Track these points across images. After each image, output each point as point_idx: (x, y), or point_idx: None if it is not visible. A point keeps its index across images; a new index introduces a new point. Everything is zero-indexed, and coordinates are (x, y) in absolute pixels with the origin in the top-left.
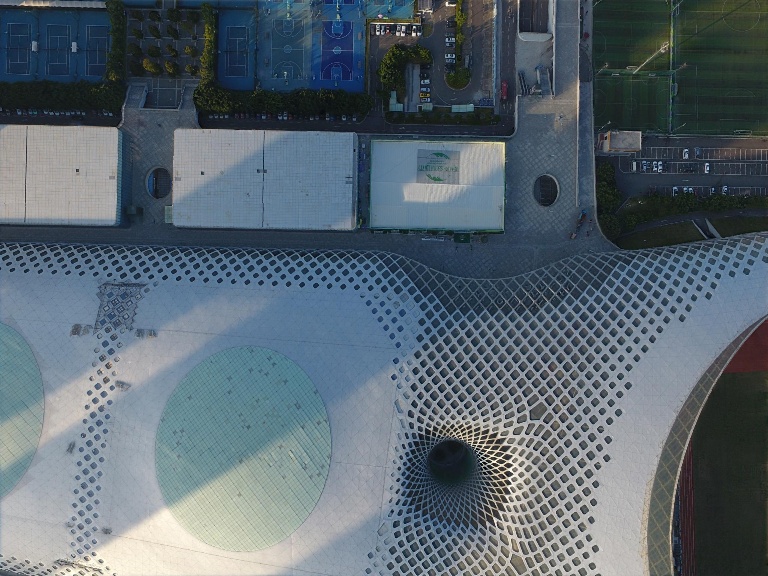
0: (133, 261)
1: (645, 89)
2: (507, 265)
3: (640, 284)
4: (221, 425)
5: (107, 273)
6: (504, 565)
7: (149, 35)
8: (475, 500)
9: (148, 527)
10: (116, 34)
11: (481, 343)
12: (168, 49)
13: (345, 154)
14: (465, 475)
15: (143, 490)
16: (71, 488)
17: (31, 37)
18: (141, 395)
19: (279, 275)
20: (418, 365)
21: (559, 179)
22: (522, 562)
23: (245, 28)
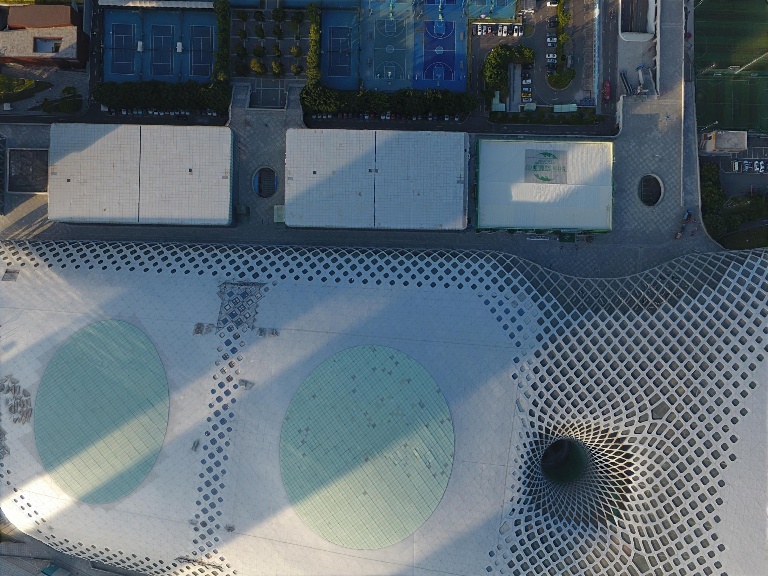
0: (250, 260)
1: (747, 89)
2: (612, 265)
3: (757, 284)
4: (347, 424)
5: (226, 272)
6: (626, 564)
7: (252, 35)
8: (593, 499)
9: (271, 525)
10: (223, 34)
11: (600, 342)
12: (275, 49)
13: (456, 154)
14: (576, 474)
15: (267, 488)
16: (195, 486)
17: (135, 37)
18: (265, 394)
19: (396, 274)
20: (538, 364)
21: (663, 179)
22: (644, 561)
23: (348, 28)
